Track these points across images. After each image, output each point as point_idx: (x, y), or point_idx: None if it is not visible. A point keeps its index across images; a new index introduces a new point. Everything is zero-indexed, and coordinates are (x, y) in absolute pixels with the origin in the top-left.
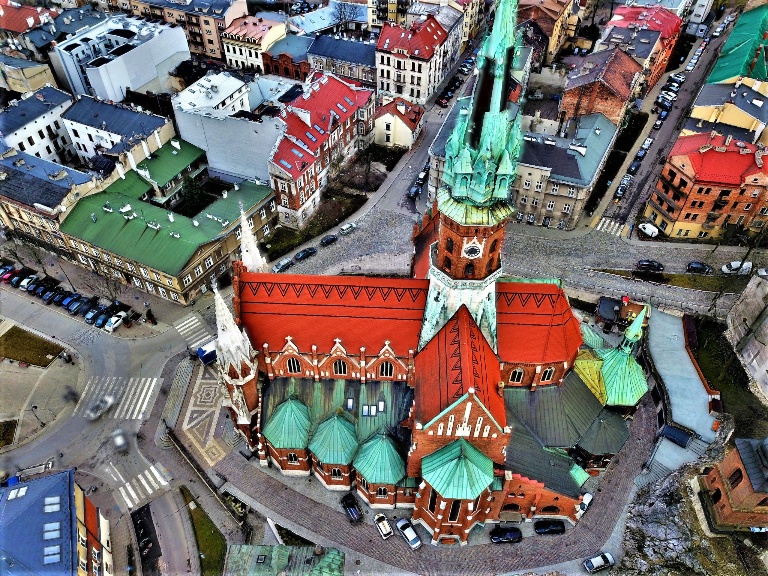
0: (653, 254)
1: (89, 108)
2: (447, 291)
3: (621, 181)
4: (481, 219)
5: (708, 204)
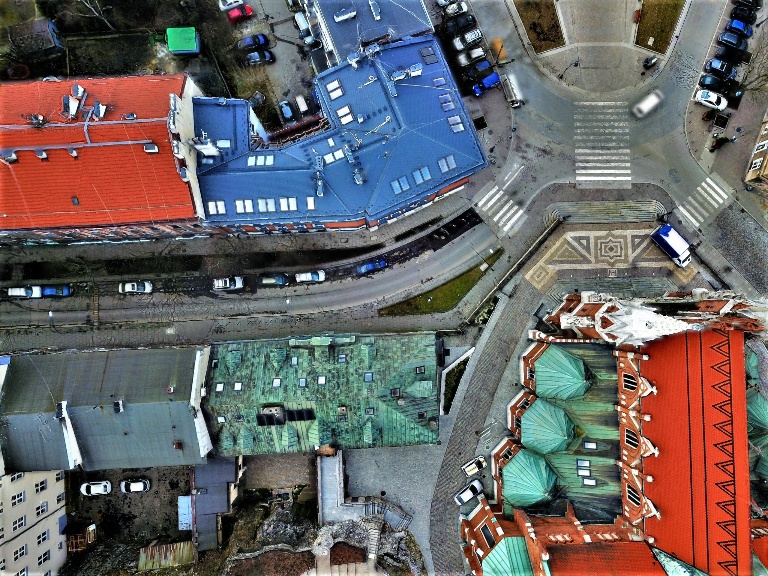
0: None
1: None
2: None
3: None
4: None
5: None
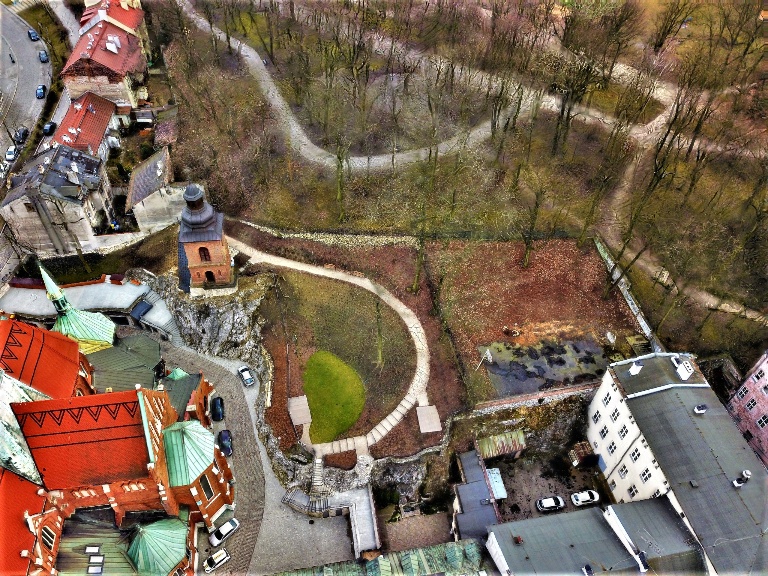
0: None
1: None
2: None
3: None
4: None
5: None
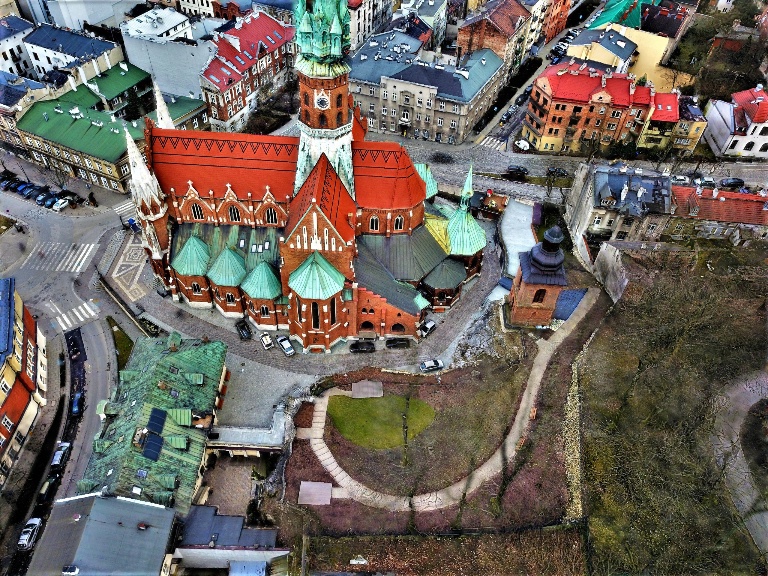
0: (522, 163)
1: (48, 34)
2: (309, 141)
3: (508, 109)
4: (324, 72)
5: (565, 119)
